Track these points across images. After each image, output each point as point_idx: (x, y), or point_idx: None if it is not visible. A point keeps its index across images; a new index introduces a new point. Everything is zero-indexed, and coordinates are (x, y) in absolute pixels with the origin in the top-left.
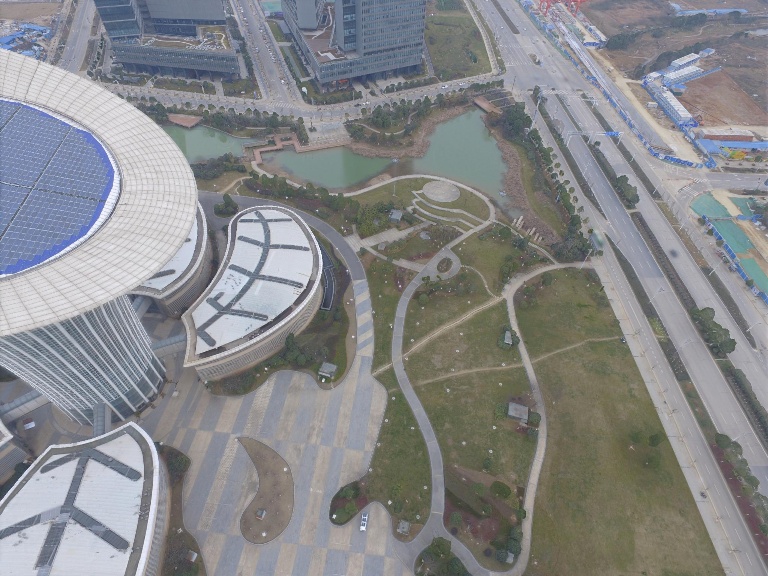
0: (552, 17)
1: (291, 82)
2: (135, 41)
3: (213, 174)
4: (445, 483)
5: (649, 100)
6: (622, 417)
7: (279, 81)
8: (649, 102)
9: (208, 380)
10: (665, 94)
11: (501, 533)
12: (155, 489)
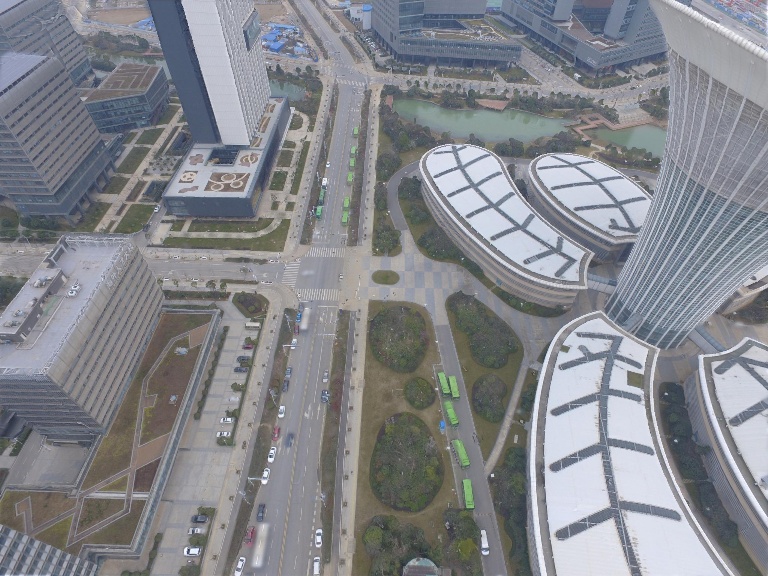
0: (740, 7)
1: (555, 69)
2: (420, 34)
3: (572, 148)
4: None
5: None
6: None
7: (543, 69)
8: None
9: (728, 312)
10: None
11: None
12: None
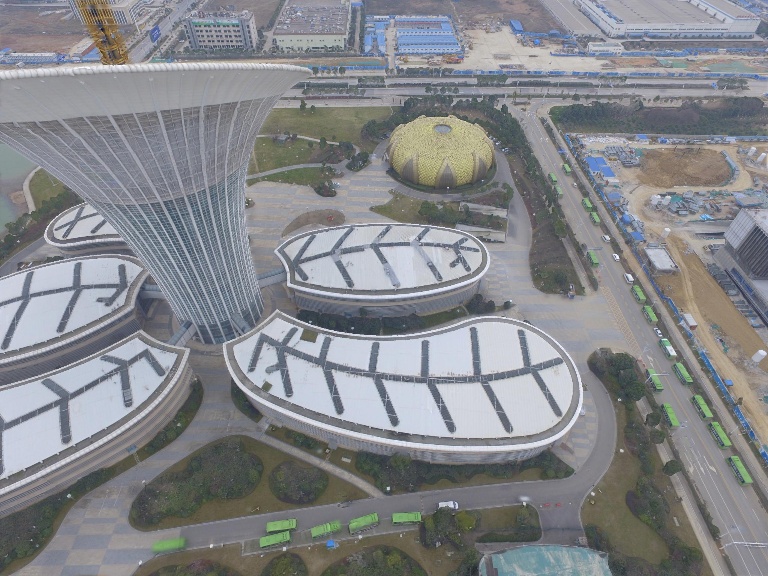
0: None
1: None
2: None
3: None
4: (317, 162)
5: (10, 66)
6: (289, 115)
7: None
8: (16, 64)
9: None
10: (14, 55)
11: (341, 149)
12: (321, 229)
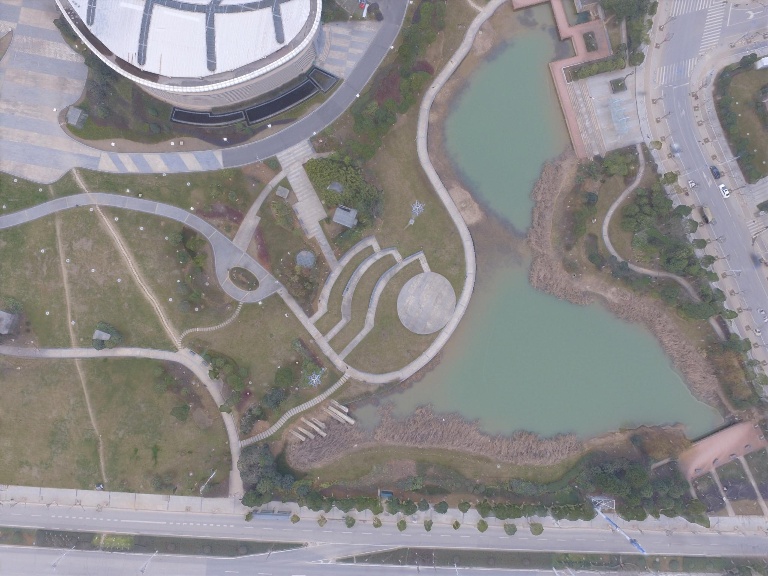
0: None
1: None
2: None
3: None
4: None
5: None
6: None
7: None
8: None
9: None
10: None
11: None
12: None
